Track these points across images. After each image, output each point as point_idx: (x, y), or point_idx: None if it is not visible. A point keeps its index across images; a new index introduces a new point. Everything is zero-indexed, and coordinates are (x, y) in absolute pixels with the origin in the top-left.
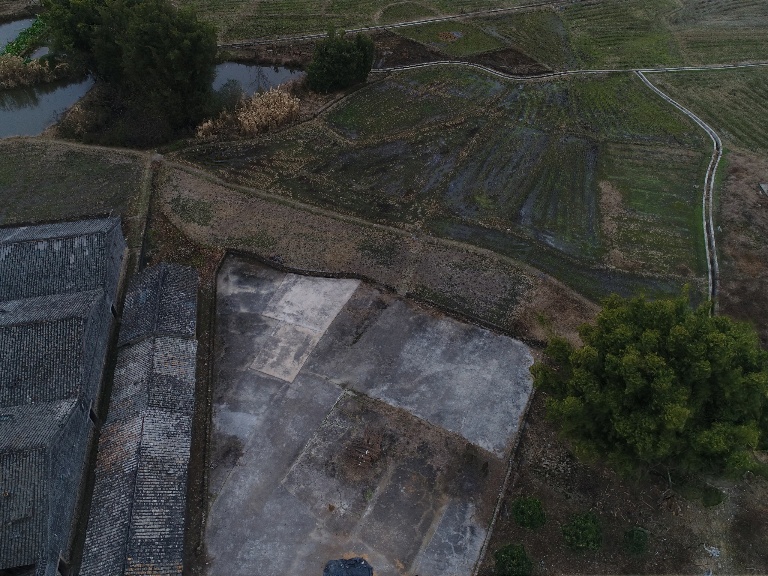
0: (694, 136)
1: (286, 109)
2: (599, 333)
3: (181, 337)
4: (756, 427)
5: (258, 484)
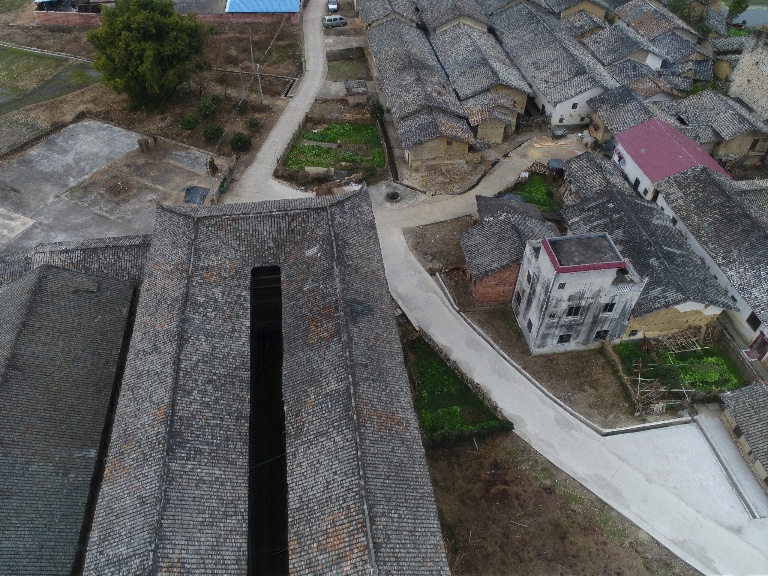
0: None
1: None
2: (111, 39)
3: None
4: None
5: (116, 232)
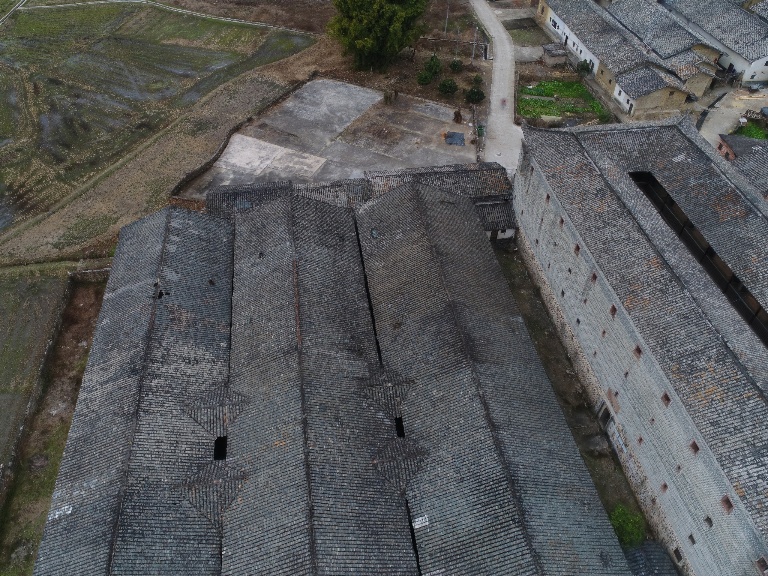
0: (127, 7)
1: None
2: None
3: None
4: None
5: (402, 167)
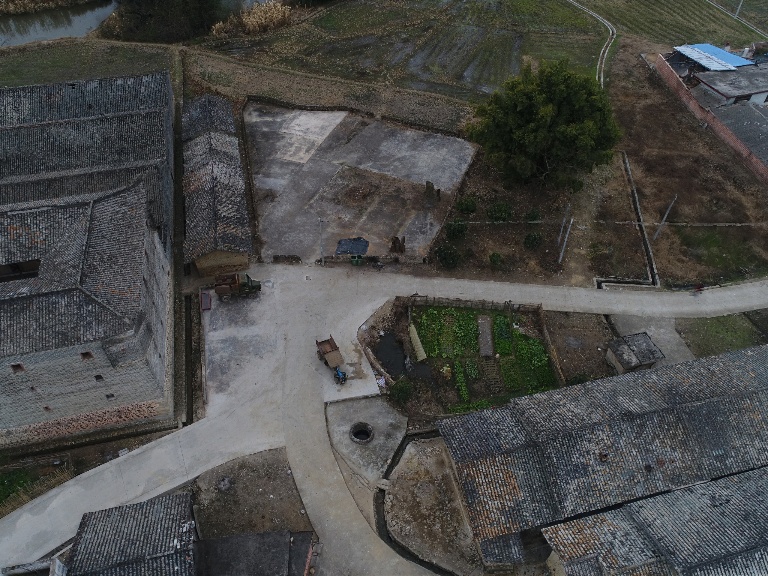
0: (596, 28)
1: (280, 14)
2: (505, 93)
3: (227, 134)
4: (596, 129)
5: (290, 209)
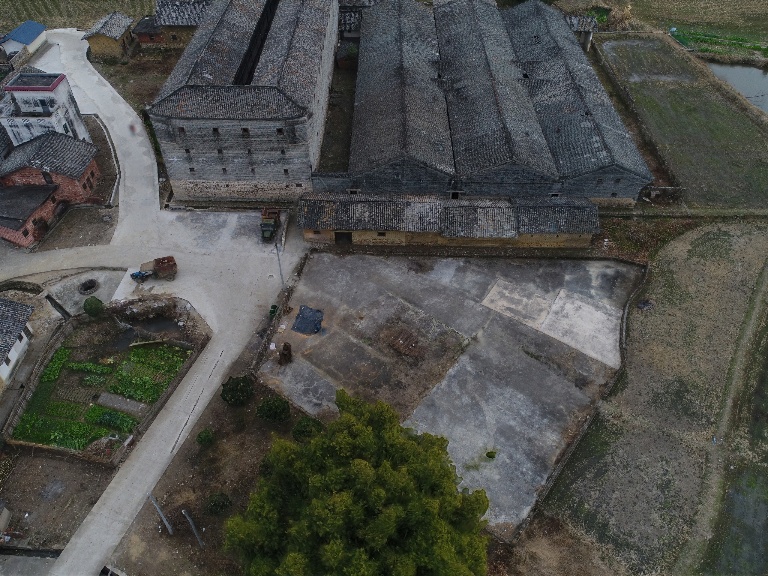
0: None
1: None
2: None
3: None
4: (262, 575)
5: (391, 280)
